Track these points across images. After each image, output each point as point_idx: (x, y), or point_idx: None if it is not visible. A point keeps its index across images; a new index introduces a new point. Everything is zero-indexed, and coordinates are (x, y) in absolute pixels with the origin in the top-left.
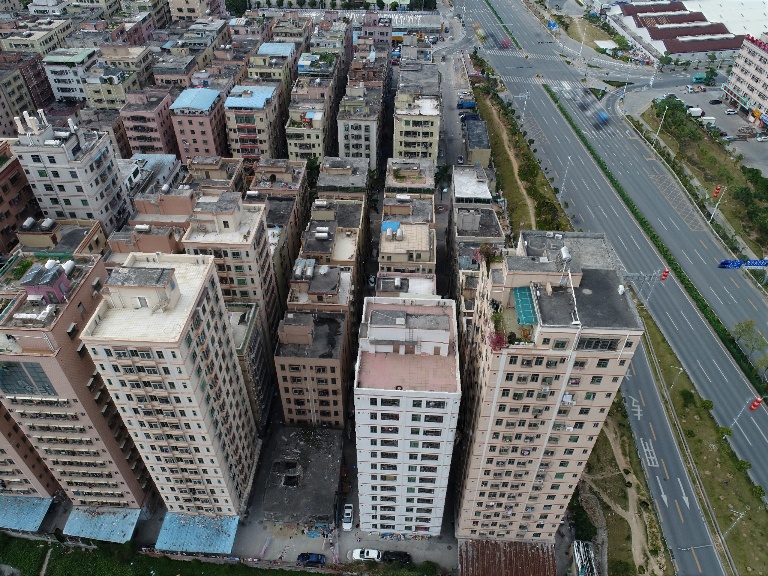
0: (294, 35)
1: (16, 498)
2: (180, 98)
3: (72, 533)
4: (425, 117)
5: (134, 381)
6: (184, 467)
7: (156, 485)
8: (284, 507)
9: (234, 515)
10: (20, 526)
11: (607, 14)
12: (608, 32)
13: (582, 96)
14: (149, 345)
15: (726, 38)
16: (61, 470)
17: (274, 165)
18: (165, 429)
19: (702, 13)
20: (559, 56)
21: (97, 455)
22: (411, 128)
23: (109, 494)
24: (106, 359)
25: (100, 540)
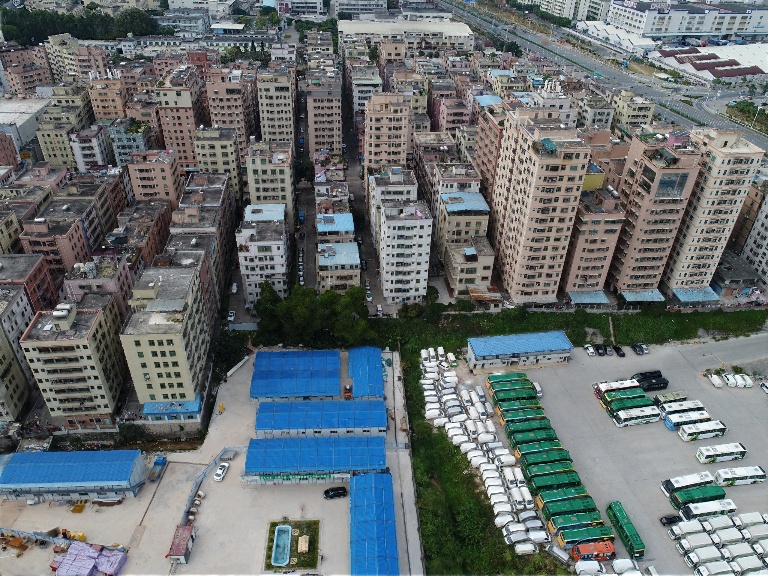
0: (494, 67)
1: (582, 292)
2: (480, 101)
3: (632, 300)
4: (646, 105)
5: (729, 180)
6: (708, 246)
7: (681, 264)
8: (736, 277)
9: (708, 286)
10: (599, 302)
11: (649, 57)
12: (657, 68)
13: (678, 104)
14: (751, 155)
15: (745, 68)
16: (639, 257)
17: (599, 127)
18: (719, 215)
19: (716, 54)
20: (639, 83)
21: (667, 241)
22: (636, 113)
23: (648, 277)
24: (725, 167)
25: (650, 301)
